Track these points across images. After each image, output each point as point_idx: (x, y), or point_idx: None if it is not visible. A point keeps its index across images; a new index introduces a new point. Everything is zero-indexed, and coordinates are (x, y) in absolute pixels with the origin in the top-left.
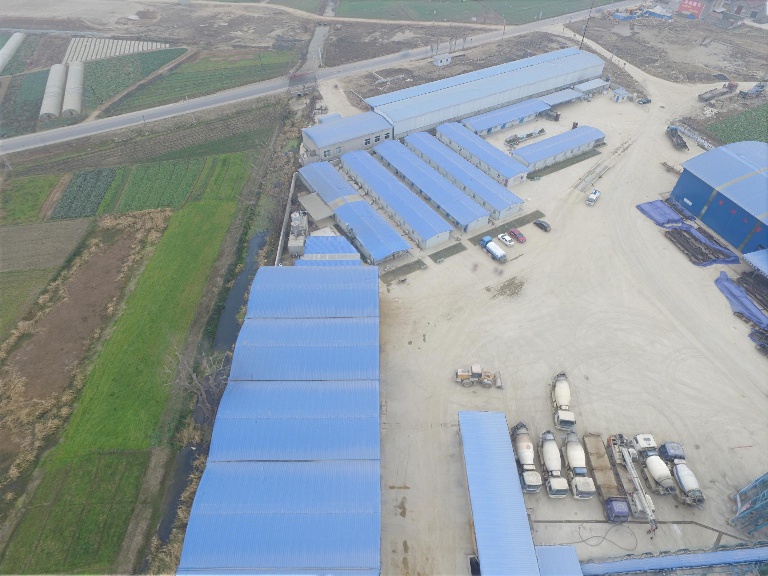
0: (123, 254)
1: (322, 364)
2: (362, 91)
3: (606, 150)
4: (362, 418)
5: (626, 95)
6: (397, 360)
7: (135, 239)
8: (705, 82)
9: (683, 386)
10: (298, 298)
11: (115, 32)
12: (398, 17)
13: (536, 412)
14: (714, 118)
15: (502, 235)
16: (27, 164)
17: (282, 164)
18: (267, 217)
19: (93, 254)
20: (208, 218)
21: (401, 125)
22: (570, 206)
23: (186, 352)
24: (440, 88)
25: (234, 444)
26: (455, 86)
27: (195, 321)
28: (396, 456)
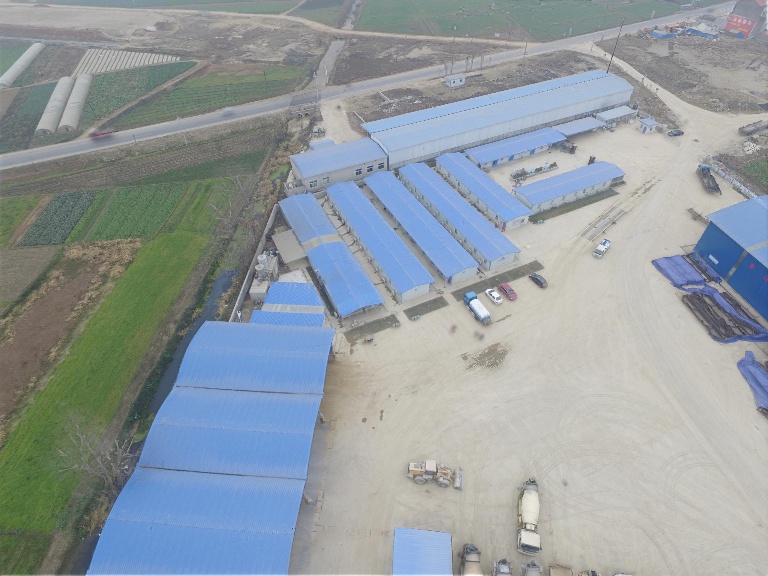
0: (81, 289)
1: (244, 454)
2: (365, 113)
3: (624, 190)
4: (273, 534)
5: (654, 126)
6: (345, 441)
7: (97, 273)
8: (749, 112)
9: (684, 504)
10: (236, 365)
11: (130, 44)
12: (418, 31)
13: (497, 525)
14: (756, 155)
15: (490, 290)
16: (12, 183)
17: (266, 193)
18: (239, 254)
19: (51, 288)
20: (177, 252)
21: (397, 154)
22: (574, 257)
23: (118, 413)
24: (446, 113)
25: (121, 555)
26: (462, 112)
27: (136, 375)
28: (322, 571)
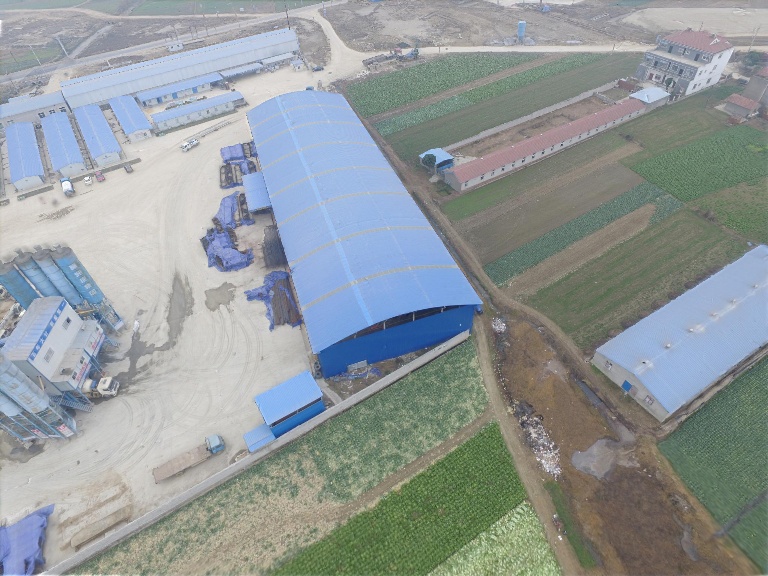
0: None
1: None
2: None
3: (244, 109)
4: None
5: (300, 65)
6: None
7: None
8: (387, 50)
9: (121, 268)
10: None
11: None
12: (183, 12)
13: None
14: (363, 79)
15: None
16: None
17: None
18: None
19: None
20: None
21: (75, 100)
22: (168, 153)
23: None
24: (134, 68)
25: None
26: (146, 66)
27: None
28: None
